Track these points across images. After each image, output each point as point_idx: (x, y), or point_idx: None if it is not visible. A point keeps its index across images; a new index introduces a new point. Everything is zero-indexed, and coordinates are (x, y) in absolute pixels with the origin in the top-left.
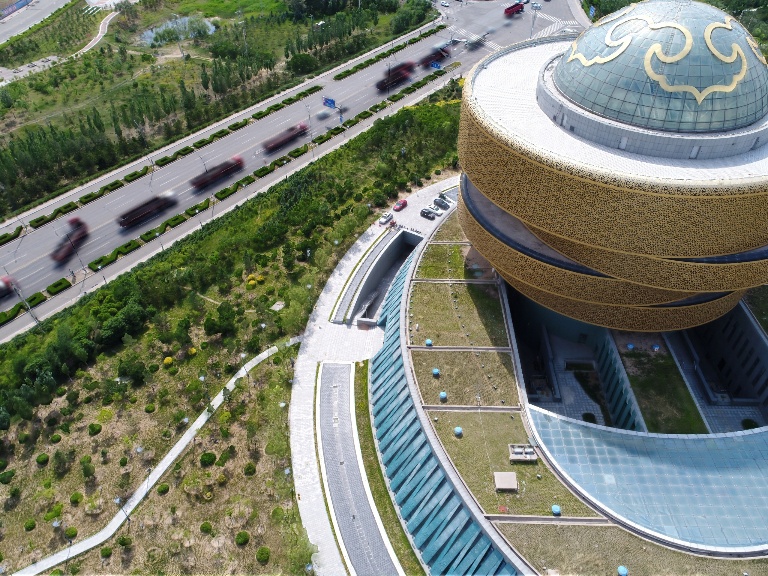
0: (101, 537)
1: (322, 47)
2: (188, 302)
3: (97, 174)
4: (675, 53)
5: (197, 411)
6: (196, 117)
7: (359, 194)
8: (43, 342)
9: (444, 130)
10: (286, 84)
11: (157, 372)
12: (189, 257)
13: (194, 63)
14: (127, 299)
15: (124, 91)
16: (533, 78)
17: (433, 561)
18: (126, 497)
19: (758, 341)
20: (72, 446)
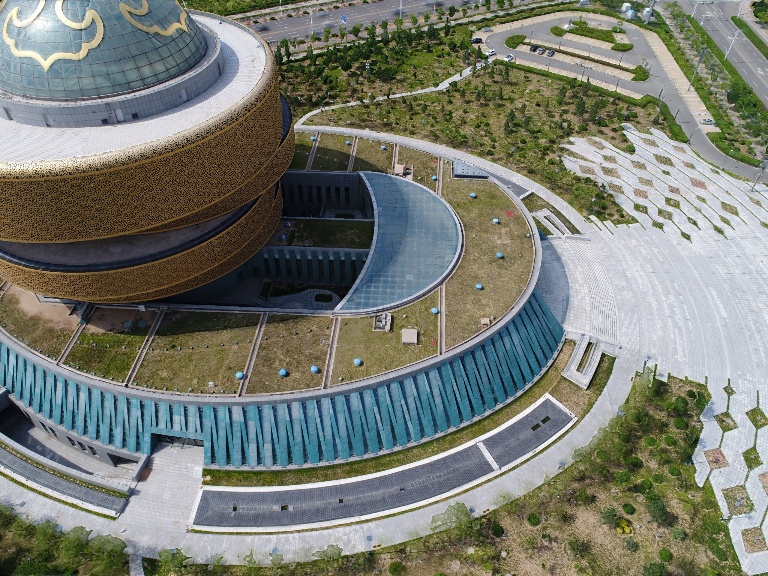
0: None
1: None
2: None
3: None
4: (139, 4)
5: None
6: None
7: None
8: None
9: None
10: None
11: None
12: None
13: None
14: None
15: None
16: None
17: (448, 421)
18: None
19: (290, 177)
20: None
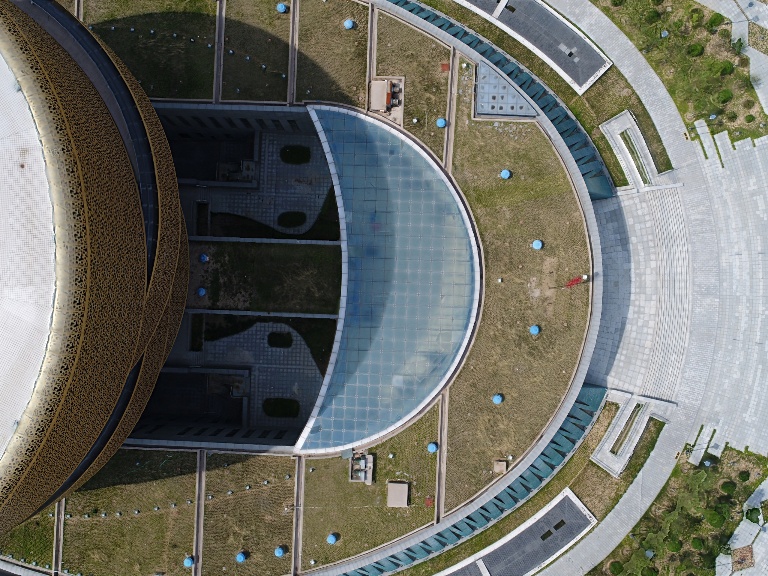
0: None
1: None
2: None
3: None
4: None
5: None
6: None
7: None
8: None
9: None
10: None
11: None
12: None
13: None
14: None
15: None
16: None
17: None
18: None
19: (189, 112)
20: None
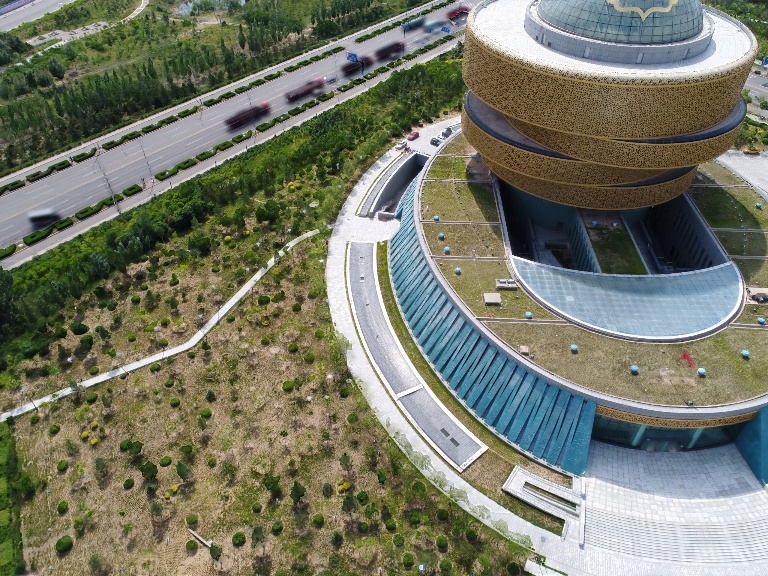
0: (186, 346)
1: (344, 16)
2: (239, 202)
3: (155, 111)
4: None
5: (253, 271)
6: (236, 69)
7: (379, 126)
8: (125, 226)
9: (452, 81)
10: (313, 45)
11: (219, 247)
12: (238, 171)
13: (230, 28)
14: (192, 196)
15: (170, 50)
16: (523, 14)
17: (437, 360)
18: (203, 323)
19: (697, 223)
20: (157, 292)
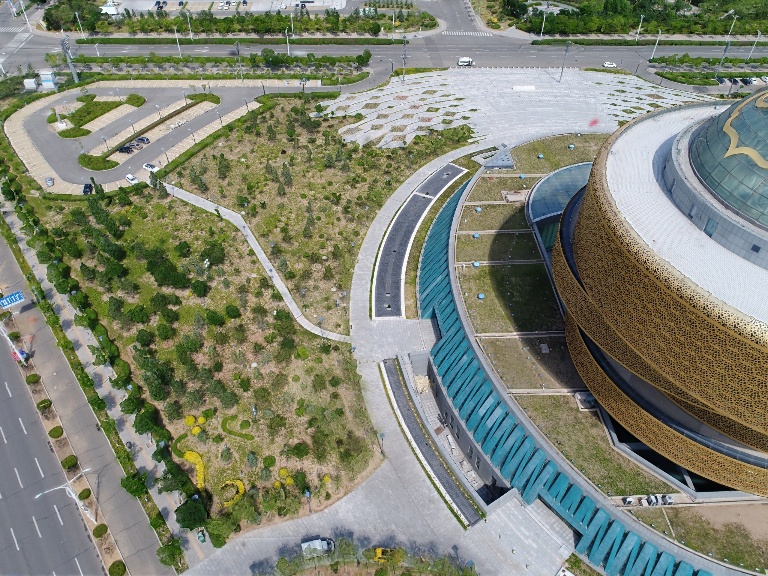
0: None
1: None
2: None
3: None
4: None
5: None
6: None
7: None
8: None
9: None
10: None
11: None
12: None
13: None
14: None
15: None
16: None
17: None
18: None
19: None
20: None
